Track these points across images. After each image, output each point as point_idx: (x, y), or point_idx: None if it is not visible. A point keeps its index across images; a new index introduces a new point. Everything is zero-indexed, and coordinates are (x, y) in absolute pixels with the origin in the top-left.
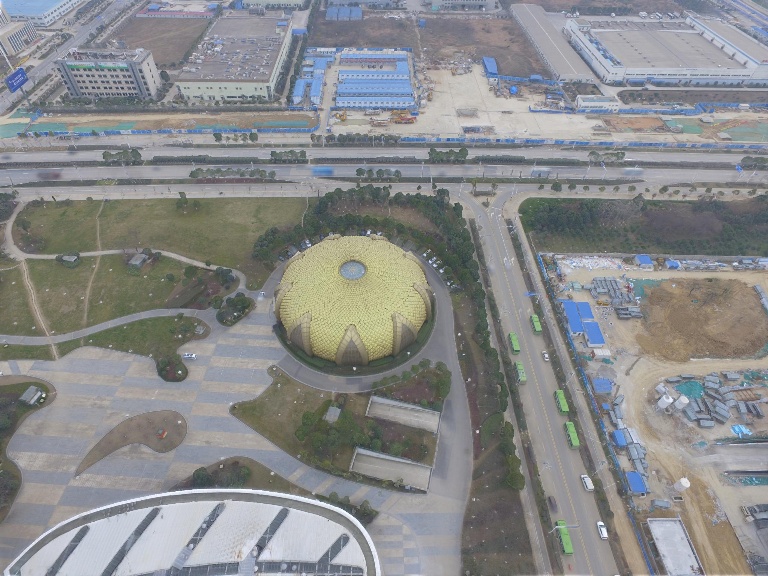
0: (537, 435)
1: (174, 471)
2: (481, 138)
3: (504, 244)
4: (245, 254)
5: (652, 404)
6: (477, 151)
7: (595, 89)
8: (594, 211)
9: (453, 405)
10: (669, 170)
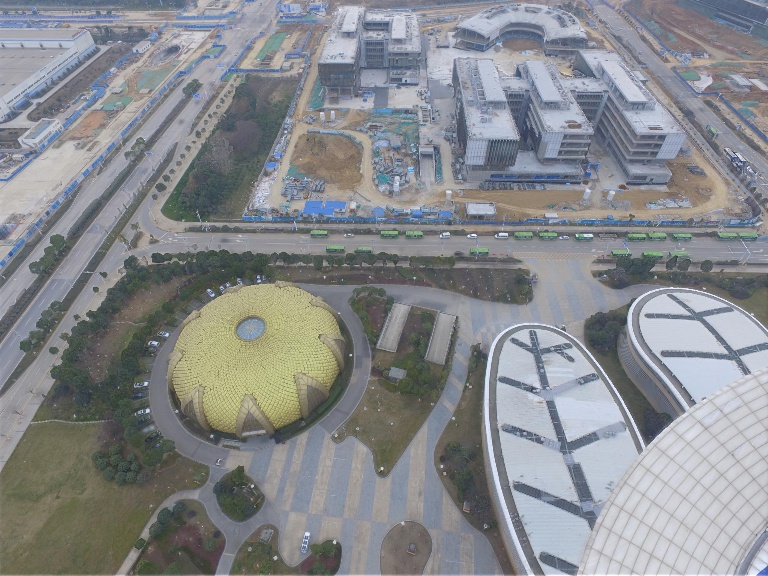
0: (412, 253)
1: (451, 524)
2: (30, 226)
3: (218, 238)
4: (129, 498)
5: (393, 196)
6: (53, 234)
7: (7, 131)
8: (213, 170)
9: (388, 294)
10: (171, 127)
